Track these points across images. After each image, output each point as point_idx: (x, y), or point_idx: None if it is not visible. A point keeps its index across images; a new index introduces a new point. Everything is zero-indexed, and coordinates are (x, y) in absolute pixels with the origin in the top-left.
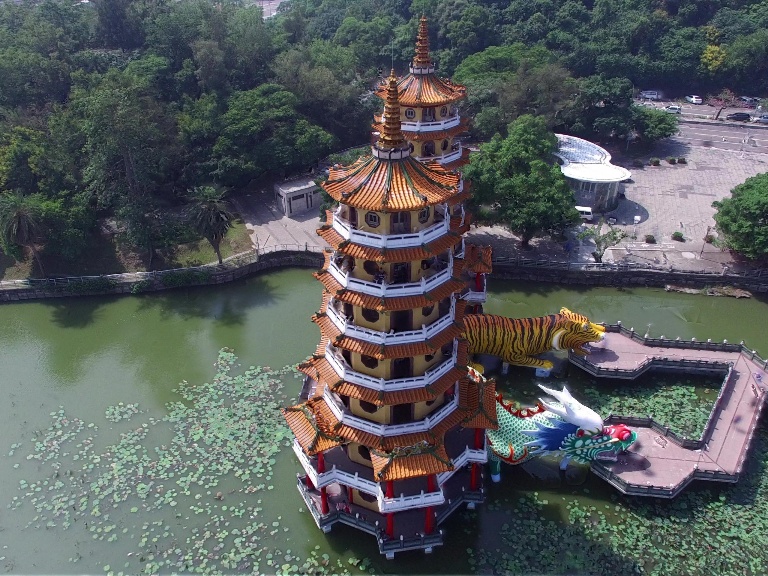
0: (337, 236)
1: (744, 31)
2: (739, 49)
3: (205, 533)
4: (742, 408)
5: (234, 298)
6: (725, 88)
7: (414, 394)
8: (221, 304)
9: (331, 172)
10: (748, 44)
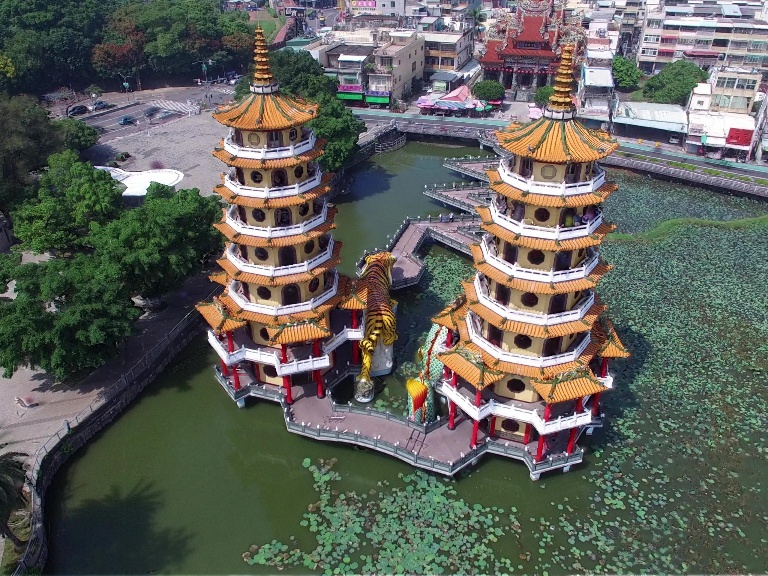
0: (578, 198)
1: (2, 34)
2: (22, 51)
3: (576, 568)
4: (466, 241)
5: (106, 548)
6: (61, 87)
7: (592, 291)
8: (114, 566)
9: (536, 155)
10: (26, 44)
